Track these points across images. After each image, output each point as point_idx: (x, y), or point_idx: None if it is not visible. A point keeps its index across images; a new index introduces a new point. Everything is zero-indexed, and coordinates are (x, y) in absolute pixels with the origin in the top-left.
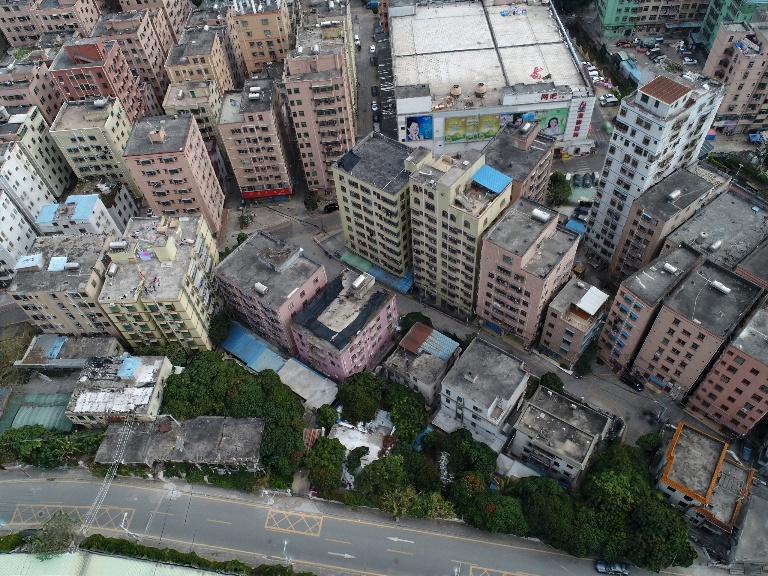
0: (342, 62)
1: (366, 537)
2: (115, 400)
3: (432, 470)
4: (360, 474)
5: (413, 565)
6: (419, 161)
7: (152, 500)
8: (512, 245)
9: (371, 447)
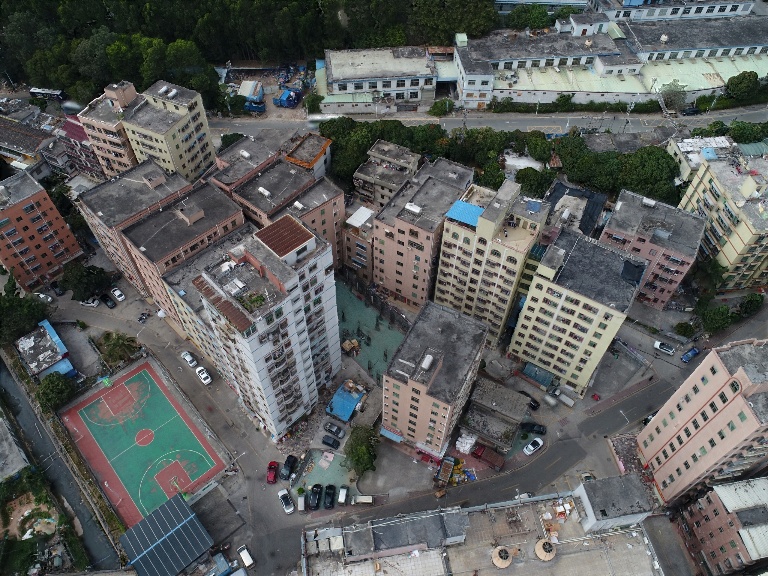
0: (735, 376)
1: (500, 129)
2: (702, 144)
3: (470, 144)
4: (514, 135)
5: (470, 123)
6: (549, 249)
7: (637, 130)
8: (438, 189)
9: (512, 163)
